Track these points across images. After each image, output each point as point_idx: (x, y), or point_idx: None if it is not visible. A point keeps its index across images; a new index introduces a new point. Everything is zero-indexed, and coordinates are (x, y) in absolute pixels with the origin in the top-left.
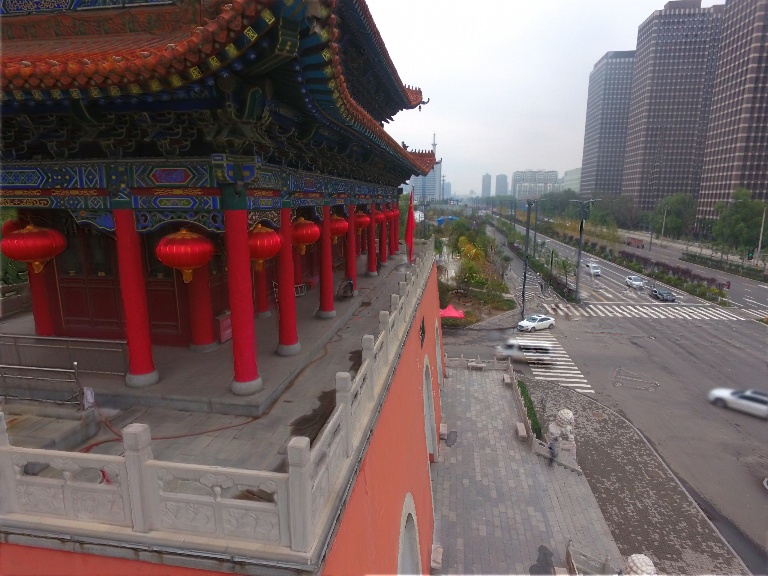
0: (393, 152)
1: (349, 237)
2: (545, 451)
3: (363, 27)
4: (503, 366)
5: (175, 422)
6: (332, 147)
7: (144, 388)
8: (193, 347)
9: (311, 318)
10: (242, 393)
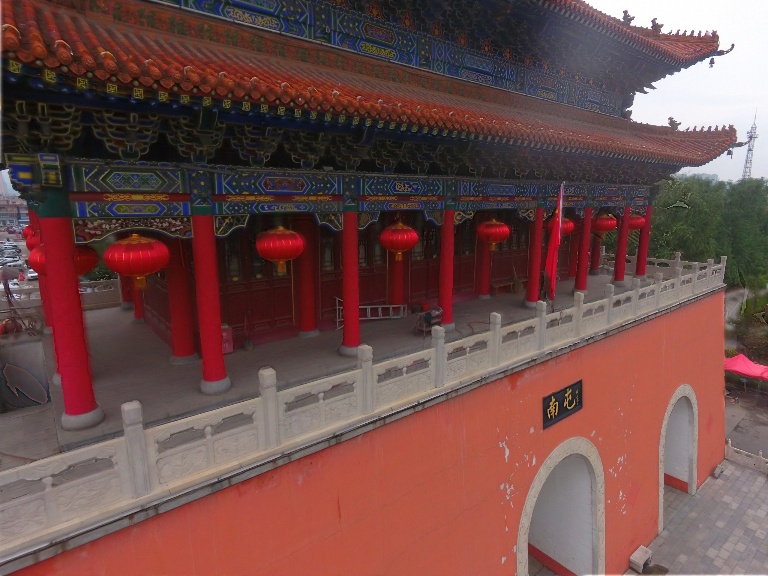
0: (447, 133)
1: (442, 253)
2: None
3: None
4: None
5: (27, 432)
6: (317, 134)
7: (58, 387)
8: (170, 356)
9: (334, 350)
10: (63, 425)
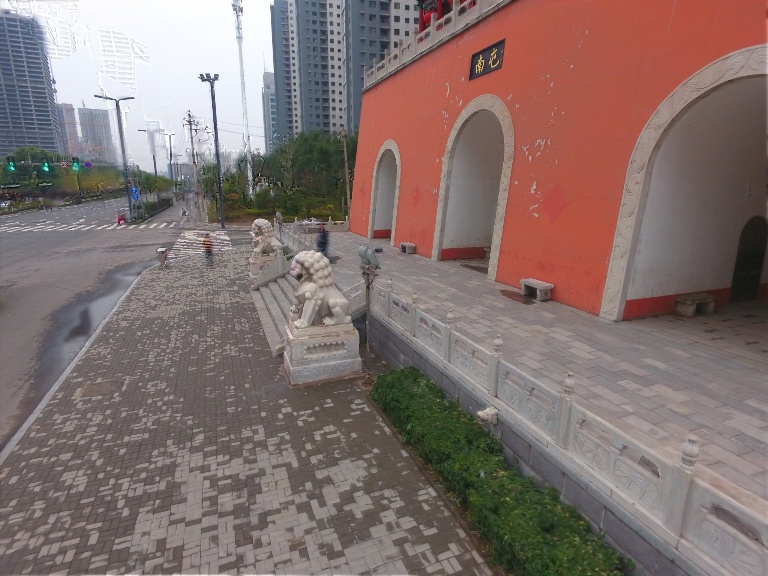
0: None
1: None
2: None
3: None
4: None
5: None
6: None
7: None
8: None
9: None
10: None
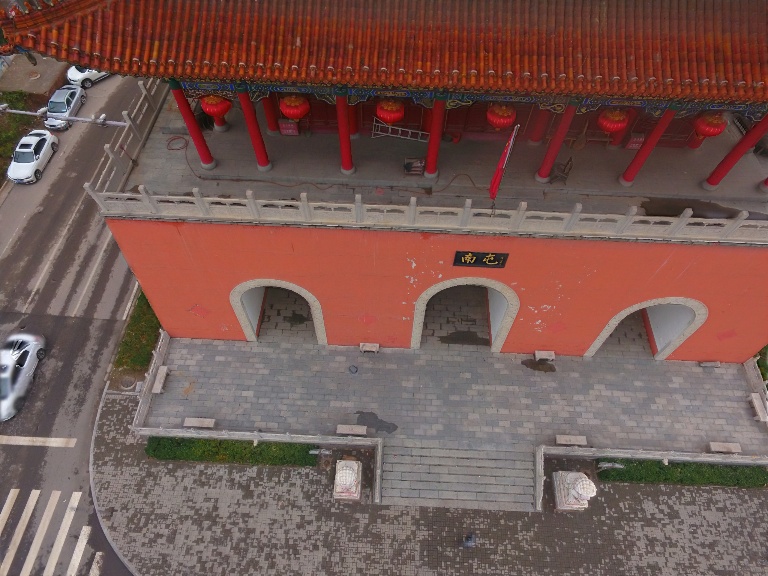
0: None
1: None
2: (539, 462)
3: None
4: None
5: None
6: None
7: None
8: None
9: None
10: None
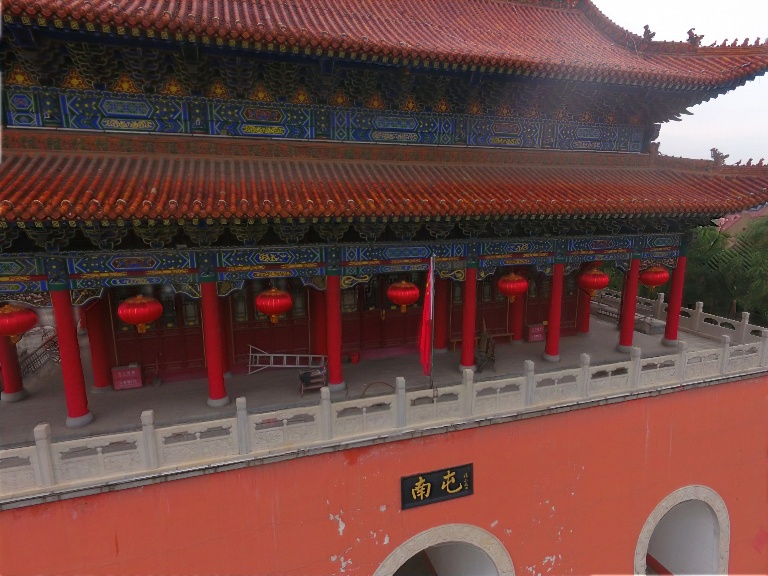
0: (254, 221)
1: (327, 316)
2: None
3: (276, 51)
4: None
5: None
6: None
7: None
8: None
9: None
10: None
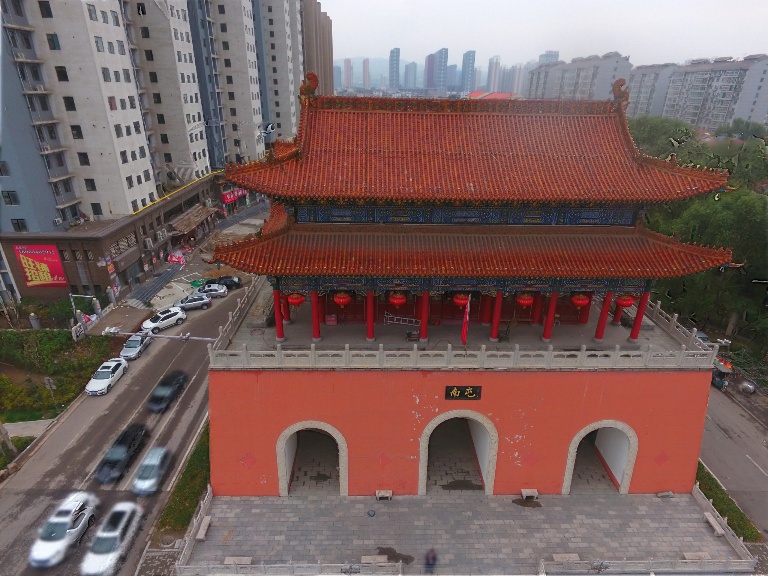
0: None
1: None
2: None
3: None
4: (746, 557)
5: (272, 336)
6: None
7: None
8: None
9: None
10: None
